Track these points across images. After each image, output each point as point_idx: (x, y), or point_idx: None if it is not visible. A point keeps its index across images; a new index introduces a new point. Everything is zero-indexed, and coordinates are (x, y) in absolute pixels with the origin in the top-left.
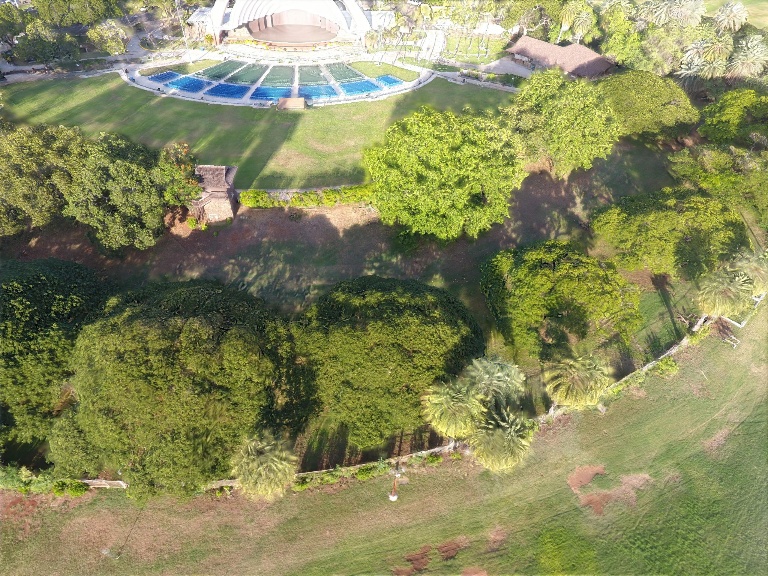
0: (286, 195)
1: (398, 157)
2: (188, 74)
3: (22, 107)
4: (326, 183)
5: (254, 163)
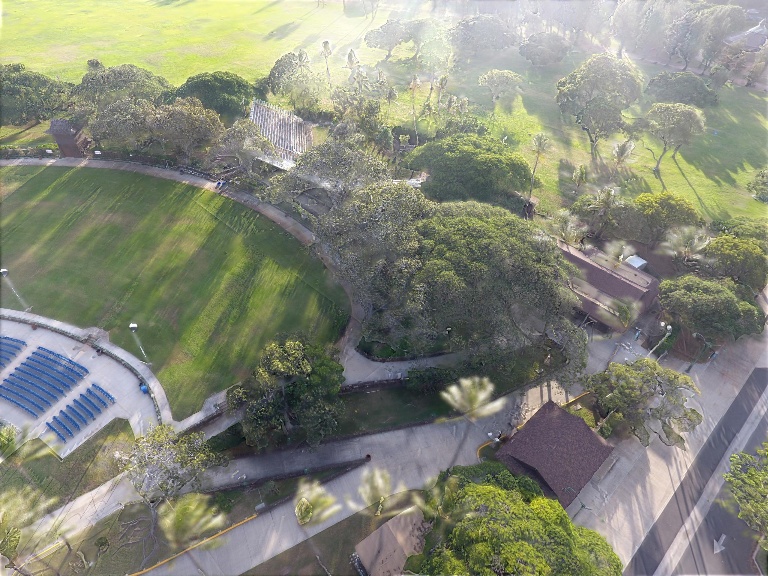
0: (22, 161)
1: None
2: (26, 442)
3: (286, 272)
4: None
5: (29, 191)
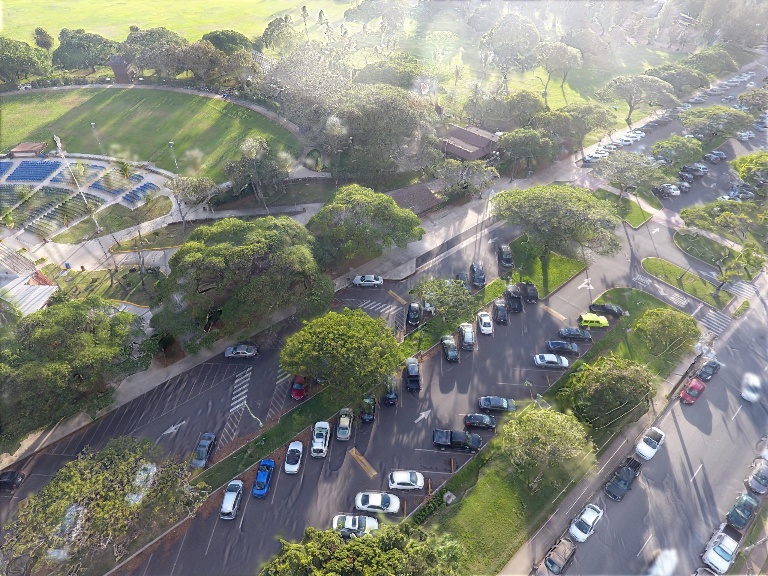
0: None
1: (23, 51)
2: (111, 204)
3: (265, 135)
4: (63, 90)
5: (97, 101)
